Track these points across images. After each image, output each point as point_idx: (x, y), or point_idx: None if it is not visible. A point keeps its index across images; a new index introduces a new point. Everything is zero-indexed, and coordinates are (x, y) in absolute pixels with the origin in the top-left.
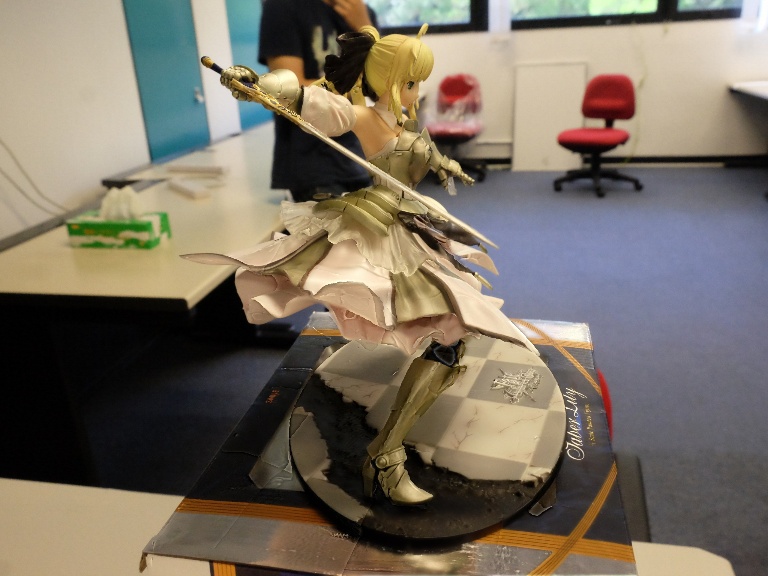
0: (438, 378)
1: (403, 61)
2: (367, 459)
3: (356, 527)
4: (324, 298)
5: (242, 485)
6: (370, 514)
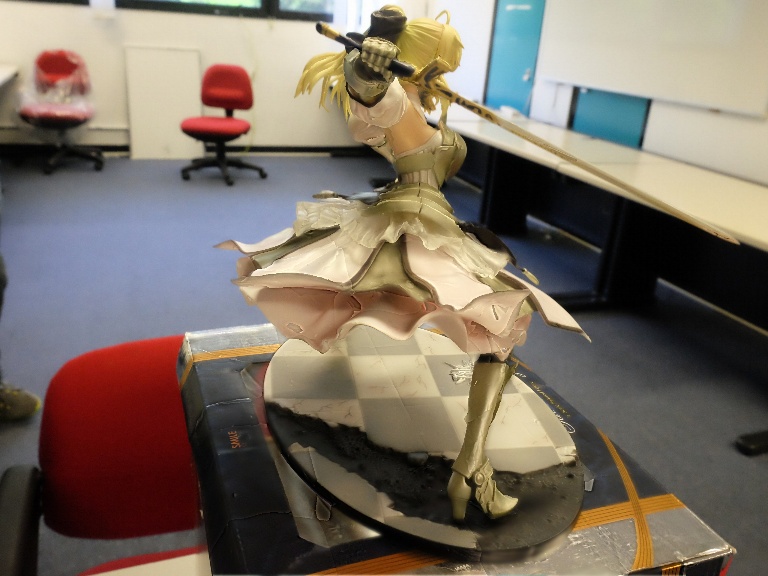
0: (397, 382)
1: (449, 49)
2: (455, 479)
3: (475, 554)
4: (465, 311)
5: (305, 551)
6: (479, 536)
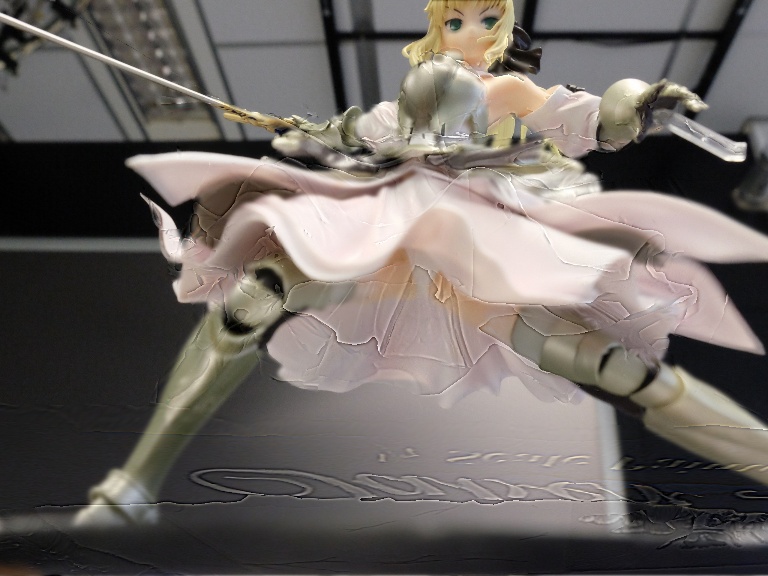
0: None
1: None
2: None
3: None
4: None
5: None
6: None
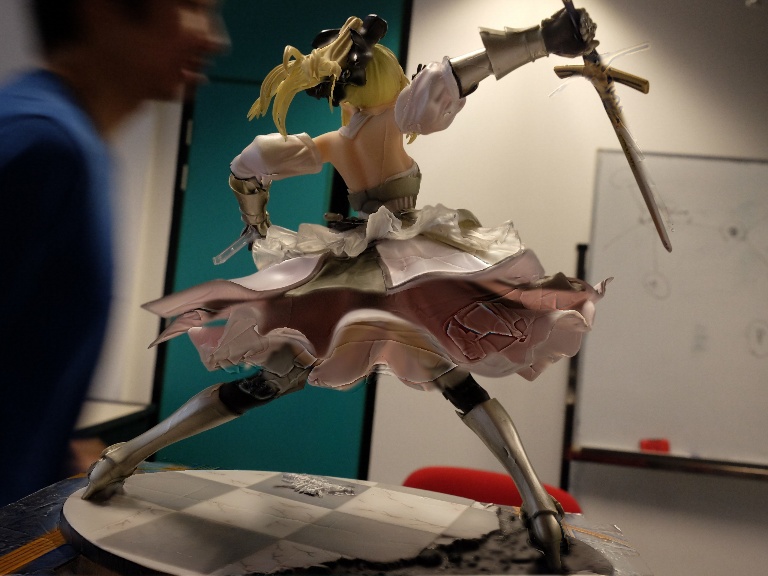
0: (276, 514)
1: None
2: (546, 522)
3: None
4: None
5: None
6: (589, 570)
